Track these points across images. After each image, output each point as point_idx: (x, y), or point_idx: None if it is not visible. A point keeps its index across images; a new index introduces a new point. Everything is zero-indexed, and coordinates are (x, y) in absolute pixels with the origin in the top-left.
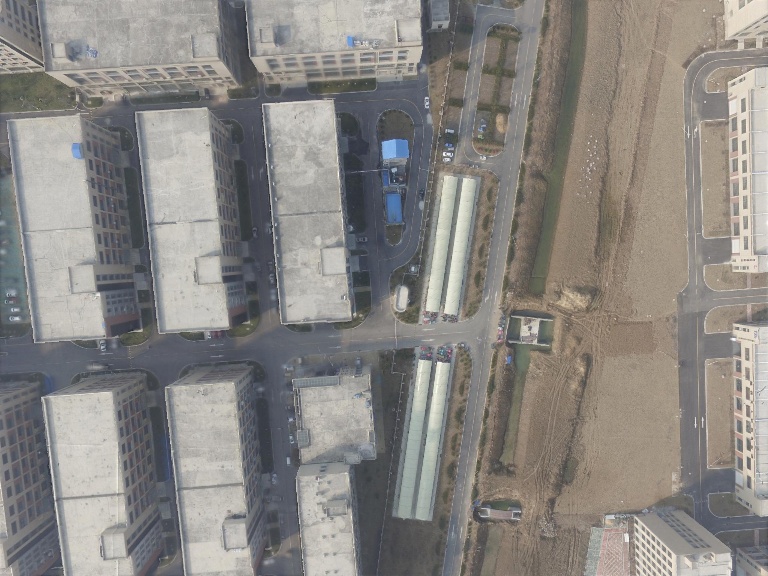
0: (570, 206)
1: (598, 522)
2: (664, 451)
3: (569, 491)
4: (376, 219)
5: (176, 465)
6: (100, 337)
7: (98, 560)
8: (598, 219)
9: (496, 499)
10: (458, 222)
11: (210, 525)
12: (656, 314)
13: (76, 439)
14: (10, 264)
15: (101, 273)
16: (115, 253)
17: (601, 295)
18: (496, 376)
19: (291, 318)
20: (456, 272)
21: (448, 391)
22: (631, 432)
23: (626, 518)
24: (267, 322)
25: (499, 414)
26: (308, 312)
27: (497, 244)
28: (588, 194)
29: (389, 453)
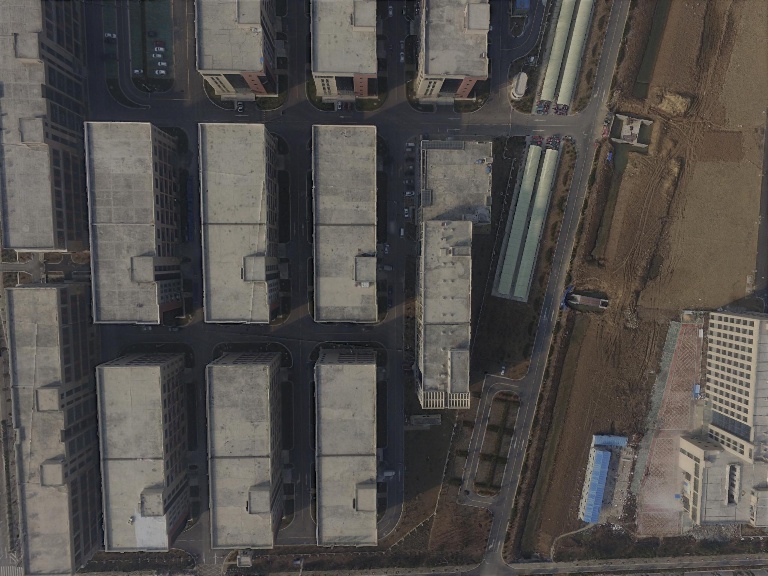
0: (678, 16)
1: (677, 317)
2: (742, 255)
3: (653, 286)
4: (502, 10)
5: (315, 201)
6: (258, 71)
7: (236, 286)
8: (702, 30)
9: (585, 289)
10: (578, 17)
11: (341, 261)
12: (746, 125)
13: (226, 168)
14: (160, 20)
15: (262, 12)
16: (268, 7)
17: (698, 103)
18: (597, 170)
19: (432, 71)
20: (572, 64)
21: (553, 180)
22: (714, 235)
23: (702, 314)
24: (393, 99)
25: (596, 207)
26: (448, 67)
27: (609, 45)
28: (695, 6)
29: (494, 234)
